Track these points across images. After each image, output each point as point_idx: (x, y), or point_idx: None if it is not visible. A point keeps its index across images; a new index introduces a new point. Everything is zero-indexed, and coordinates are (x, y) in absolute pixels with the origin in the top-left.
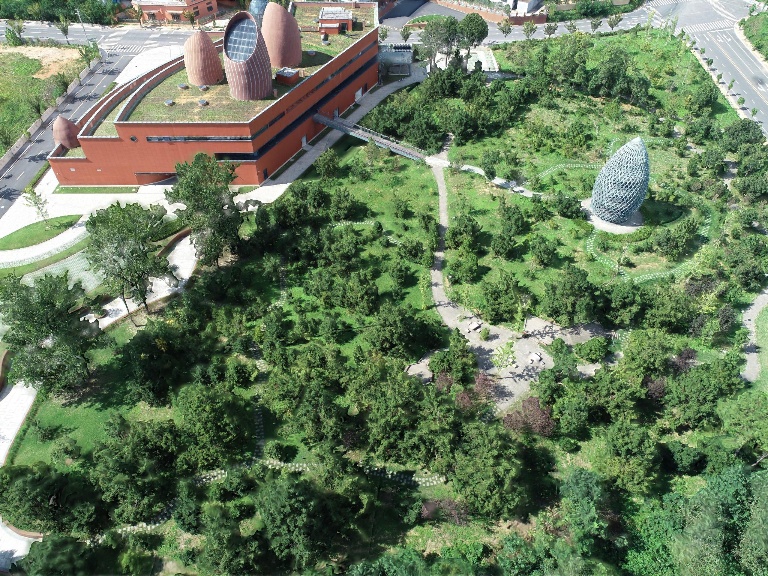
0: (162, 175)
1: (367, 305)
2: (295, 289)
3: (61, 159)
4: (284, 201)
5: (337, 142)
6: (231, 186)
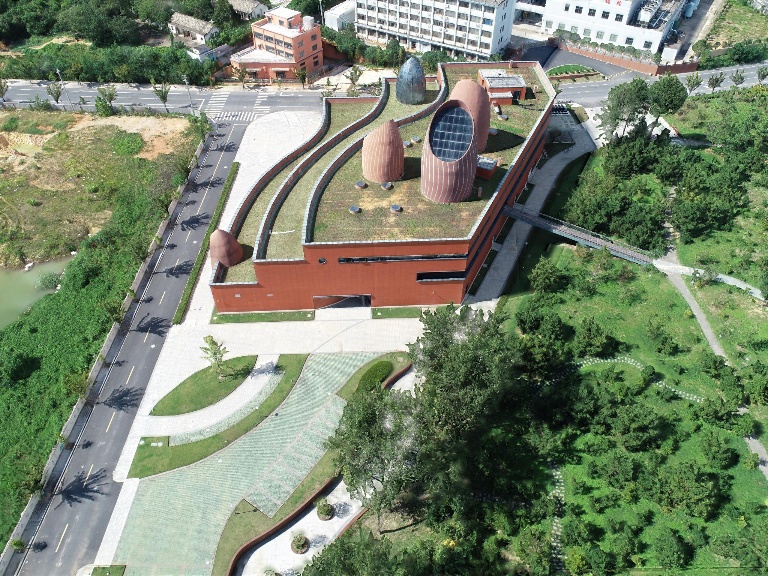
0: (345, 297)
1: (705, 509)
2: (570, 468)
3: (226, 285)
4: (526, 340)
5: (530, 239)
6: (426, 306)
